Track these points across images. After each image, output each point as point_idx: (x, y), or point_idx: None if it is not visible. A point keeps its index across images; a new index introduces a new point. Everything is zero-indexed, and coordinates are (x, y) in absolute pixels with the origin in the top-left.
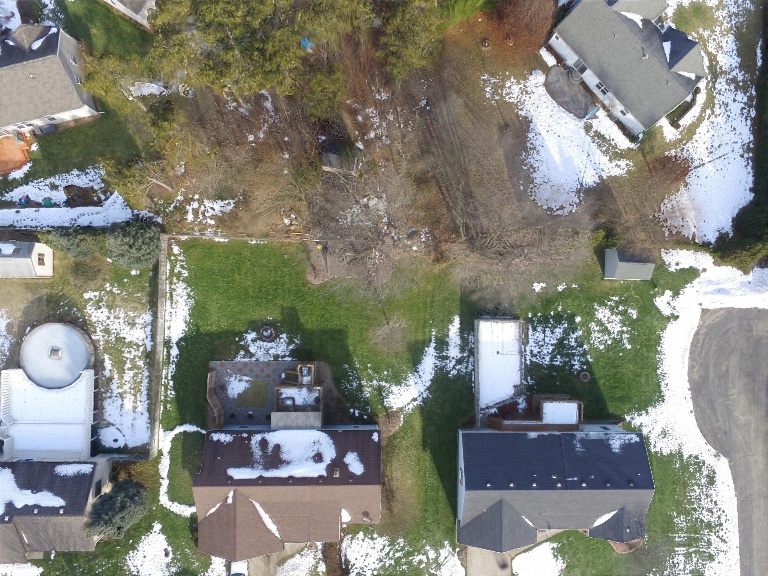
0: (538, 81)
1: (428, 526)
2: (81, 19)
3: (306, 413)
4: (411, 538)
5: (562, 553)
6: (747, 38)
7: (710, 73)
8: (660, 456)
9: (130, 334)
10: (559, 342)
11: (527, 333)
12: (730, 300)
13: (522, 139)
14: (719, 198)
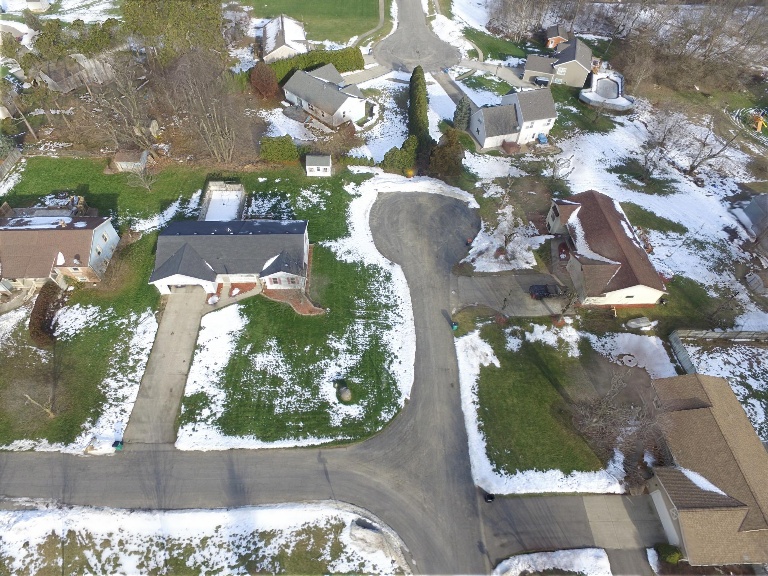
0: (278, 110)
1: (138, 299)
2: (28, 93)
3: (62, 210)
4: (120, 307)
5: (248, 312)
6: (401, 99)
7: (380, 109)
8: (344, 263)
9: None
10: (273, 206)
11: (251, 201)
12: (395, 185)
13: (264, 128)
14: (388, 149)
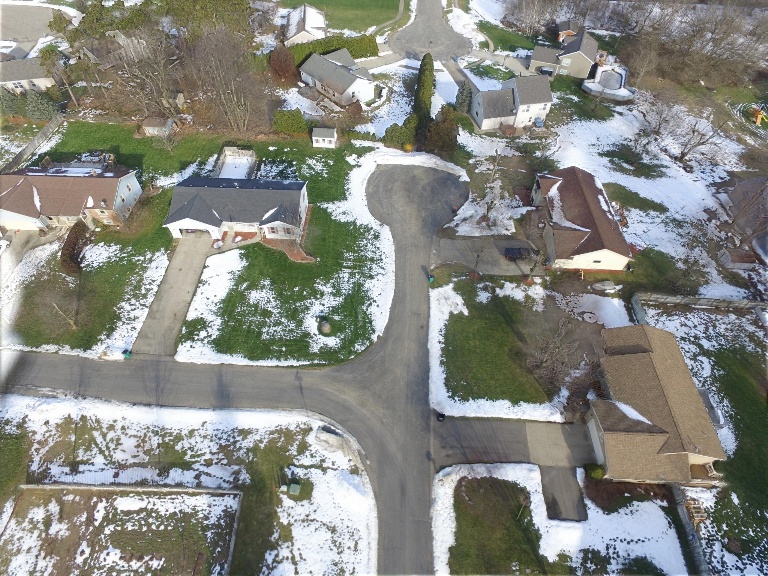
0: (294, 90)
1: (153, 241)
2: None
3: None
4: (138, 247)
5: (247, 256)
6: (409, 84)
7: (389, 92)
8: (338, 222)
9: (15, 150)
10: (280, 171)
11: (260, 166)
12: (393, 158)
13: None
14: None
